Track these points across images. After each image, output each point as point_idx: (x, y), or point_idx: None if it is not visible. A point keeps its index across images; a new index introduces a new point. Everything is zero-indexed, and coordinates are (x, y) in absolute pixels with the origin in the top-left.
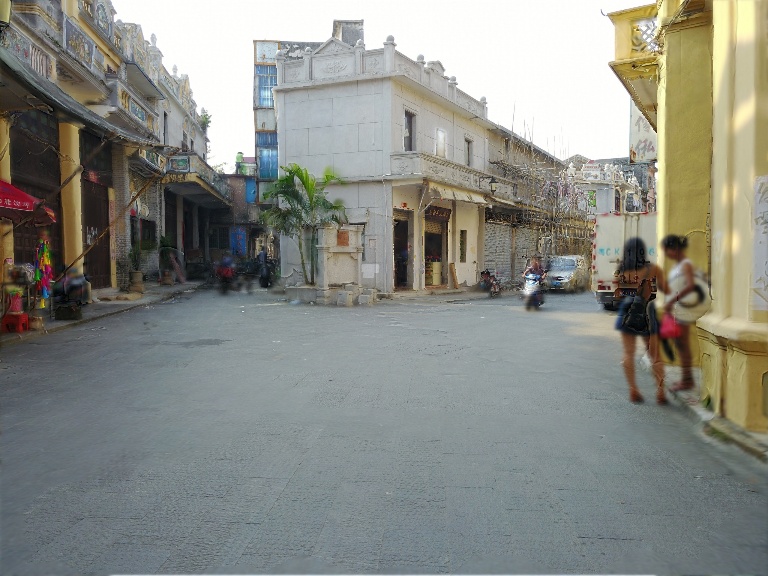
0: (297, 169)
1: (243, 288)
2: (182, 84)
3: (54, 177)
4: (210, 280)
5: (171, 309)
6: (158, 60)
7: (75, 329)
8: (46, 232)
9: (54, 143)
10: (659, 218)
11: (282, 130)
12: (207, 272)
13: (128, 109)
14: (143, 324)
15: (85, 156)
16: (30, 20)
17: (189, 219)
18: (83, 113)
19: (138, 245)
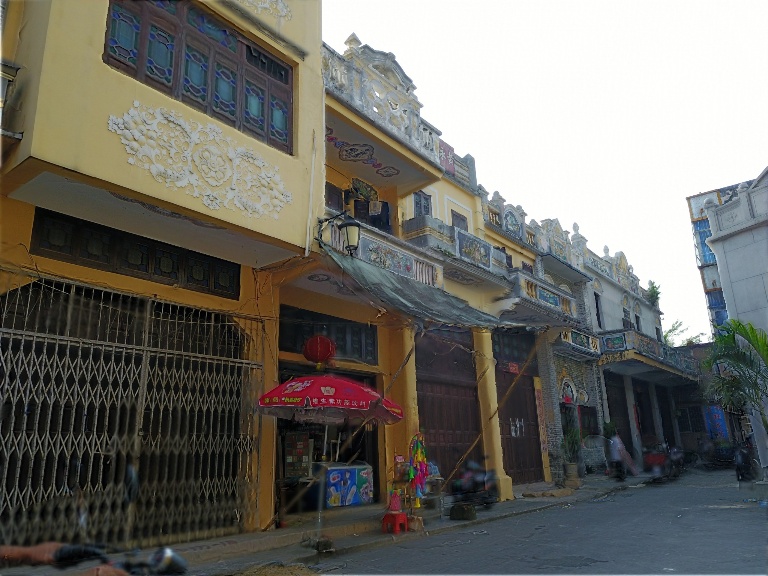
0: (737, 326)
1: (713, 482)
2: (615, 262)
3: (469, 373)
4: (673, 471)
5: (591, 510)
6: (581, 245)
7: (461, 531)
8: (463, 427)
9: (468, 342)
10: None
11: (727, 284)
12: (668, 462)
13: (536, 297)
14: (534, 529)
15: (504, 349)
16: (424, 240)
17: (646, 401)
18: (444, 309)
19: (577, 434)
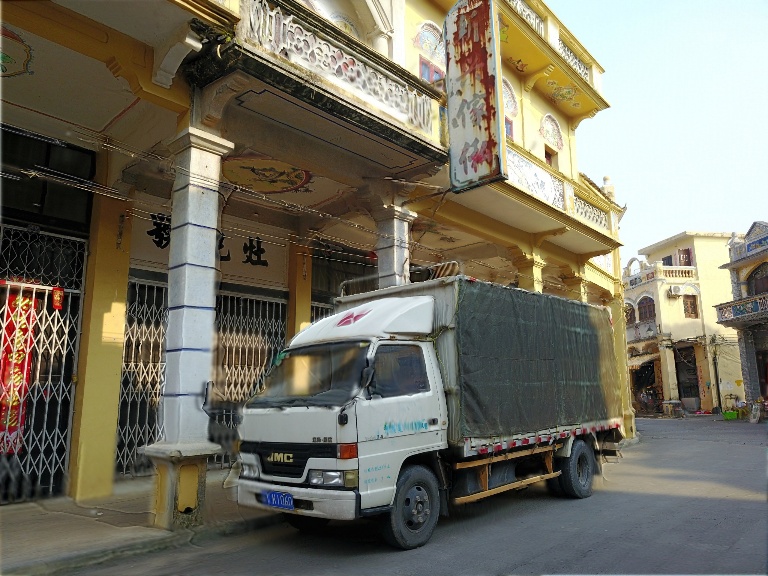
0: None
1: None
2: None
3: None
4: None
5: None
6: None
7: None
8: None
9: None
10: None
11: None
12: None
13: None
14: None
15: None
16: None
17: None
18: None
19: None
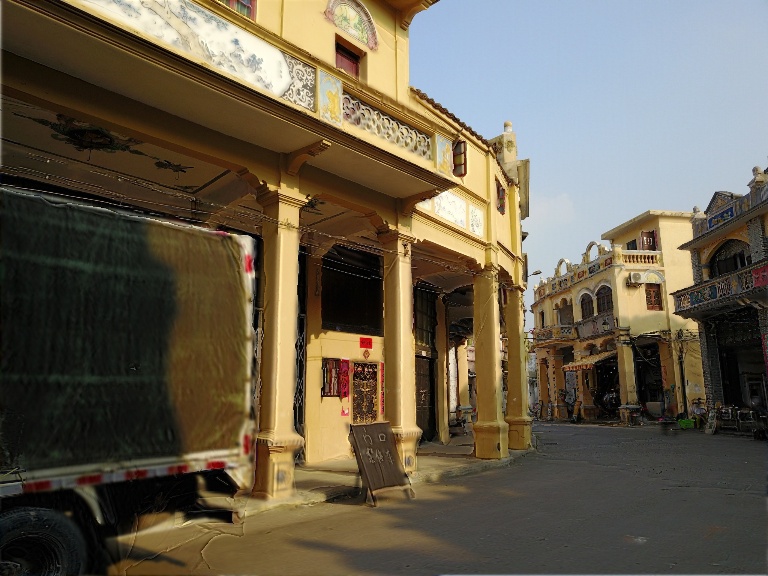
0: None
1: None
2: None
3: None
4: None
5: None
6: None
7: None
8: None
9: None
10: (497, 371)
11: None
12: None
13: None
14: None
15: None
16: None
17: None
18: None
19: None
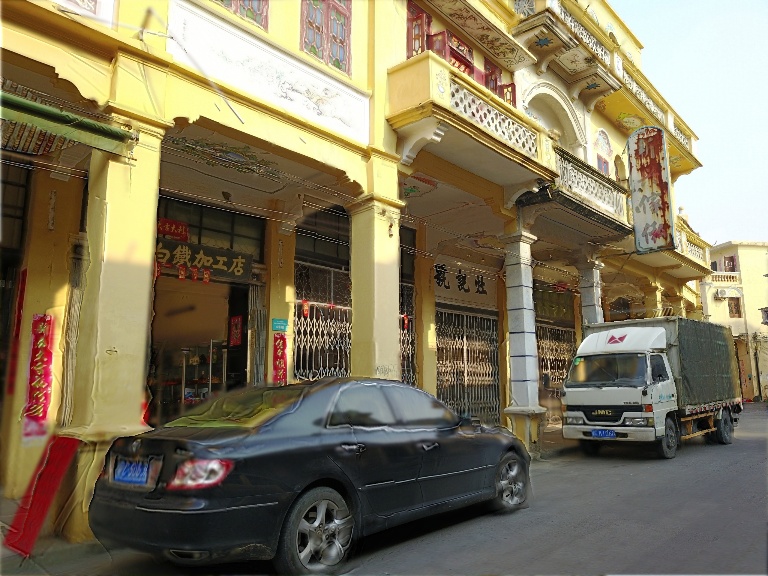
0: None
1: None
2: None
3: None
4: None
5: None
6: None
7: None
8: None
9: None
10: None
11: None
12: None
13: None
14: None
15: None
16: None
17: None
18: None
19: None
